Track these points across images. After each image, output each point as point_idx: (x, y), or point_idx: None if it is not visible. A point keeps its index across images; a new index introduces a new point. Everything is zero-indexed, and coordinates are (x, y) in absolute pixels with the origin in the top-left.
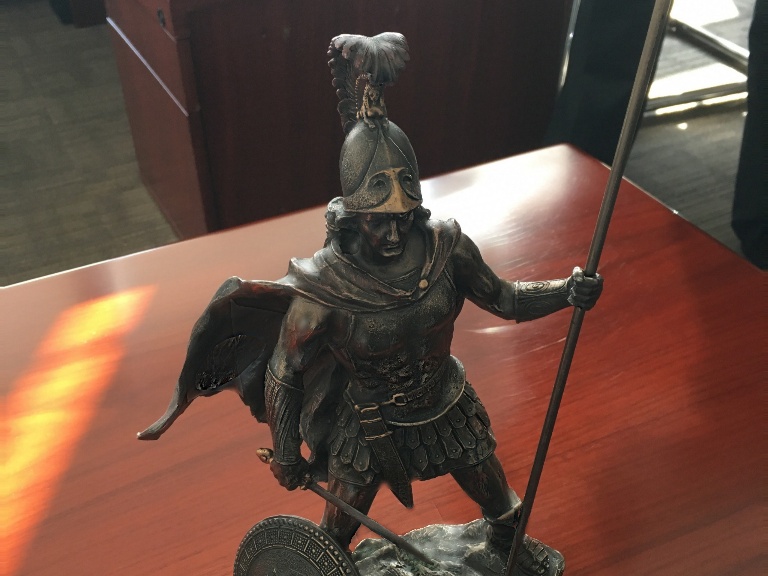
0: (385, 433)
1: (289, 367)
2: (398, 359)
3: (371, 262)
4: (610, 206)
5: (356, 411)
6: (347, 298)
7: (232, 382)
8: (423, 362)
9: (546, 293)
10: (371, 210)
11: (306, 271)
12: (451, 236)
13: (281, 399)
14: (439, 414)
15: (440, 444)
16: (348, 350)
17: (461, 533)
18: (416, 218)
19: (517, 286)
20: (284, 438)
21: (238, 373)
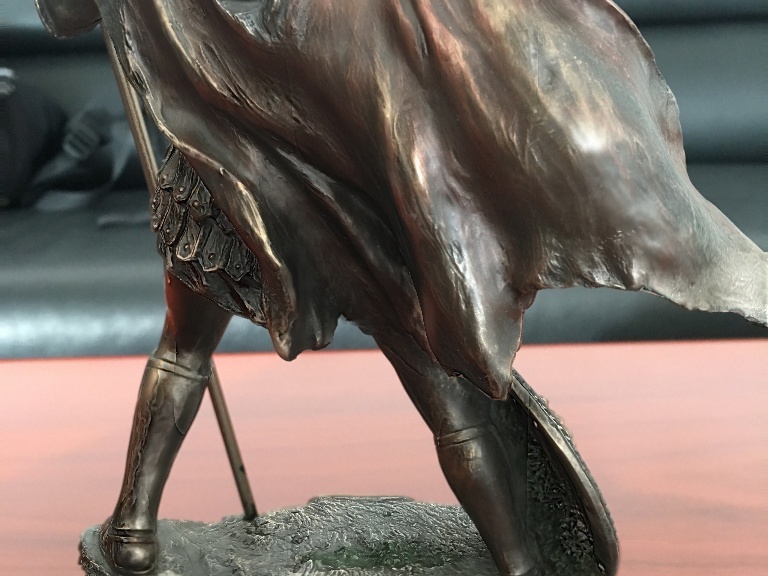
0: None
1: None
2: None
3: None
4: None
5: None
6: None
7: None
8: None
9: None
10: None
11: None
12: None
13: None
14: None
15: None
16: None
17: None
18: None
19: None
20: None
21: (535, 242)
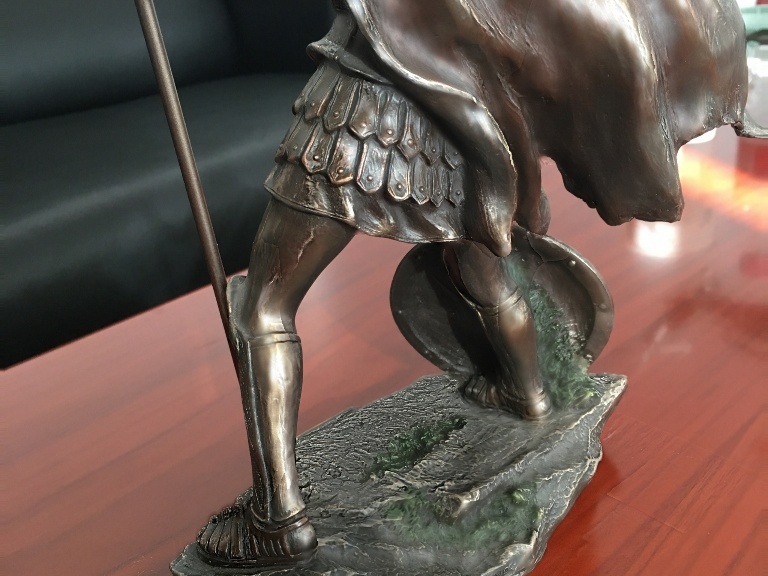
0: None
1: None
2: None
3: None
4: None
5: None
6: None
7: None
8: None
9: None
10: None
11: None
12: None
13: None
14: None
15: None
16: None
17: (370, 574)
18: None
19: None
20: None
21: (701, 103)
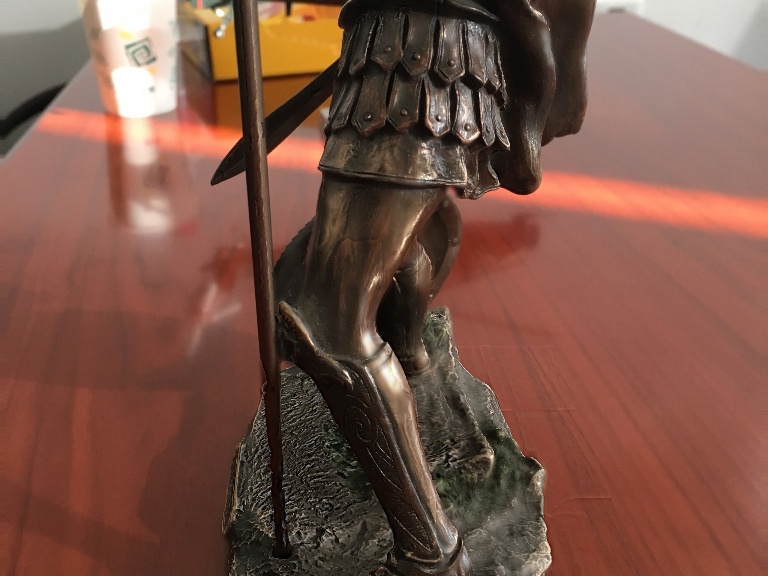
0: None
1: None
2: None
3: None
4: None
5: None
6: None
7: None
8: None
9: None
10: None
11: None
12: None
13: None
14: None
15: None
16: None
17: None
18: None
19: None
20: None
21: None
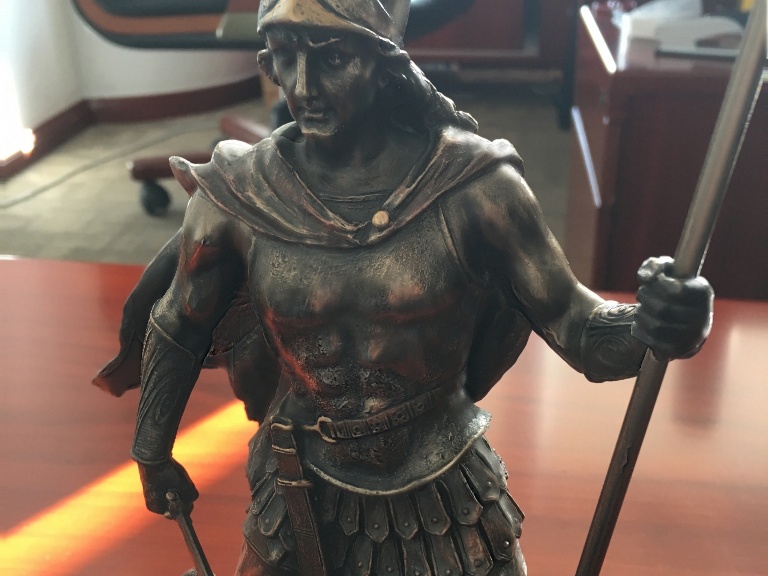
0: (297, 480)
1: (174, 304)
2: (320, 346)
3: (313, 158)
4: (740, 110)
5: (269, 425)
6: (249, 201)
7: (225, 356)
8: (368, 372)
9: (628, 321)
10: (262, 20)
11: (222, 150)
12: (471, 157)
13: (150, 350)
14: (395, 488)
15: (399, 549)
16: (253, 303)
17: None
18: (429, 116)
19: (600, 306)
20: (143, 415)
21: None
